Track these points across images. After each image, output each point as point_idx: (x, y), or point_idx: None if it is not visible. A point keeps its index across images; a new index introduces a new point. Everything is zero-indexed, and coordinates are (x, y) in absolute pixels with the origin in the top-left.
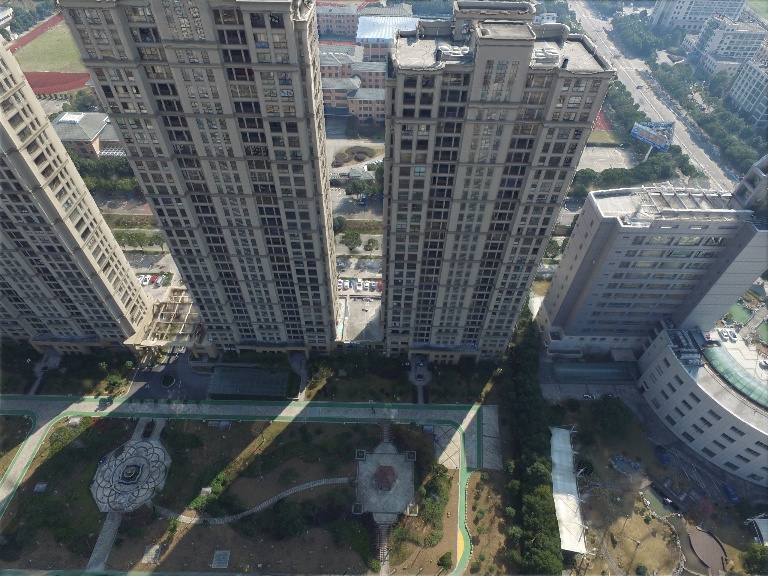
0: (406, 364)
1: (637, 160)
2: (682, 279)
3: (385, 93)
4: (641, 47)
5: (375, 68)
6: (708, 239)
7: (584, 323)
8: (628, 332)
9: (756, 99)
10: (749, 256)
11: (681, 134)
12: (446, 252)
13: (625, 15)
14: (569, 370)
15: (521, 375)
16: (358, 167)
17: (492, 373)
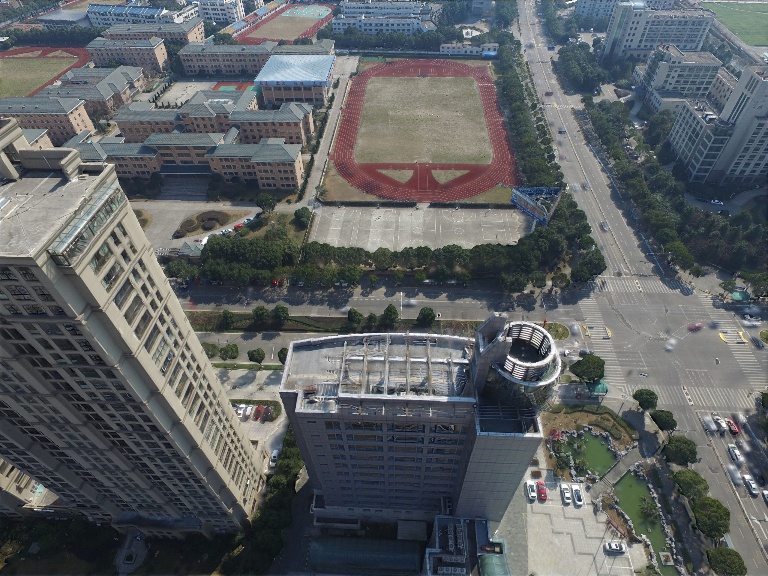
0: (115, 539)
1: (535, 226)
2: (433, 462)
3: (248, 149)
4: (582, 81)
5: (254, 118)
6: (435, 425)
7: (339, 496)
8: (407, 505)
9: (692, 148)
10: (488, 457)
11: (600, 190)
12: (53, 440)
13: (574, 44)
14: (328, 554)
15: (240, 573)
16: (200, 238)
17: (222, 557)
